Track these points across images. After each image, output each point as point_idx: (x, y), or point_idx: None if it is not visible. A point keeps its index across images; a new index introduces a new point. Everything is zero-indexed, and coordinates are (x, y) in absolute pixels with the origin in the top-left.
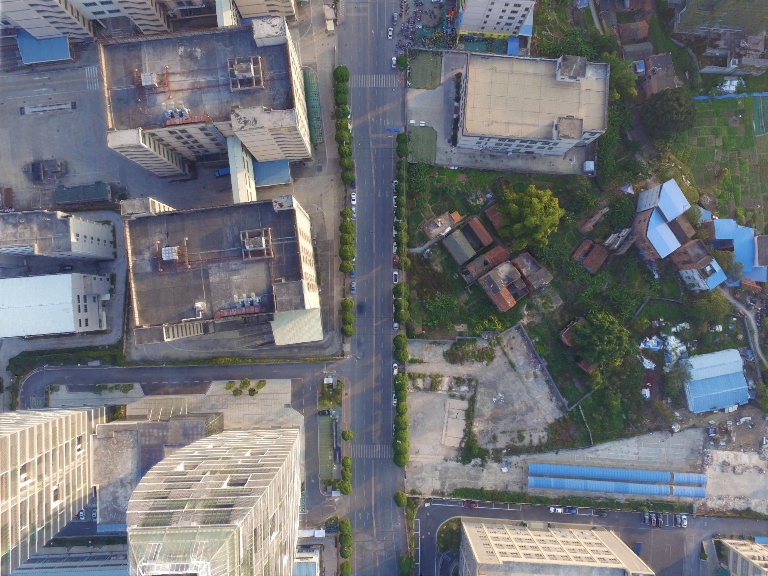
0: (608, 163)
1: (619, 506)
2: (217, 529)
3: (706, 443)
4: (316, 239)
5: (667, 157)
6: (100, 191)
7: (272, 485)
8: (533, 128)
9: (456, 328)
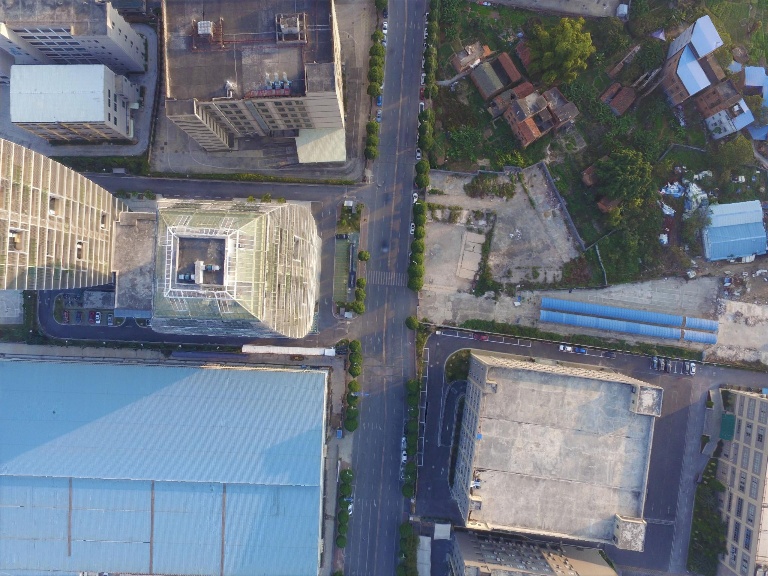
0: (642, 6)
1: (629, 348)
2: (246, 213)
3: (720, 293)
4: (345, 65)
5: (701, 8)
6: (135, 0)
7: (298, 209)
8: None
9: (478, 162)
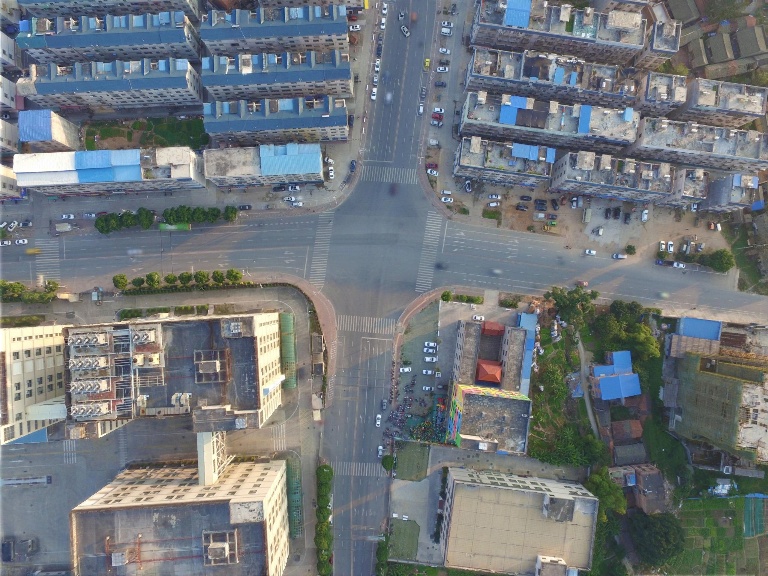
0: None
1: None
2: None
3: None
4: None
5: None
6: None
7: None
8: (516, 562)
9: None
